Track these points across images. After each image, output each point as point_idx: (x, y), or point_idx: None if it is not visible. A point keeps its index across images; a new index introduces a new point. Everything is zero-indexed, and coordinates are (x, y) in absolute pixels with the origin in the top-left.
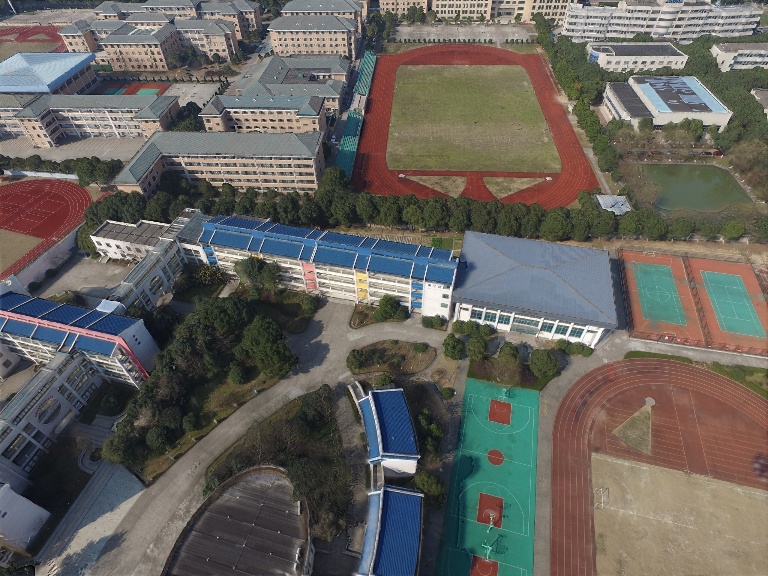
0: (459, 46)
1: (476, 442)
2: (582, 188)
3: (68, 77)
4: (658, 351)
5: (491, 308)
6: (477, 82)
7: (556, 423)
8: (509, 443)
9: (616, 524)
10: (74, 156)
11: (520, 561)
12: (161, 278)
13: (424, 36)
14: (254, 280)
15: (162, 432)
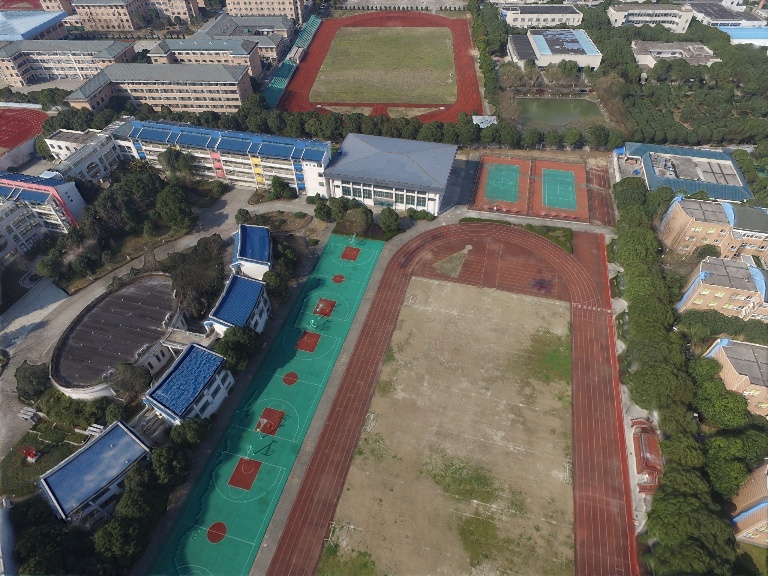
0: (398, 12)
1: (326, 270)
2: None
3: (41, 30)
4: (487, 218)
5: (355, 183)
6: (405, 40)
7: (391, 260)
8: (351, 271)
9: (415, 314)
10: None
11: (337, 334)
12: (98, 165)
13: (369, 5)
14: (173, 167)
15: (84, 259)
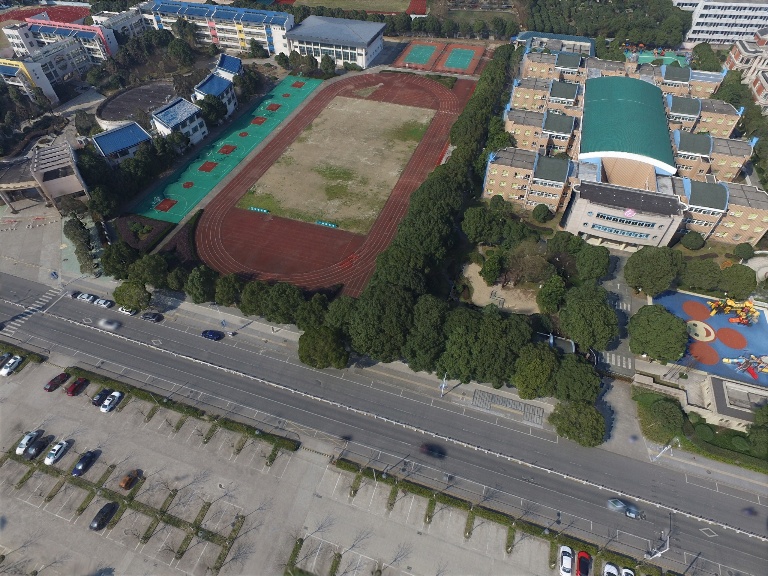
0: None
1: (279, 91)
2: None
3: None
4: None
5: (307, 42)
6: None
7: (325, 88)
8: (296, 92)
9: (332, 112)
10: None
11: (278, 118)
12: (129, 30)
13: None
14: (181, 33)
15: (117, 76)
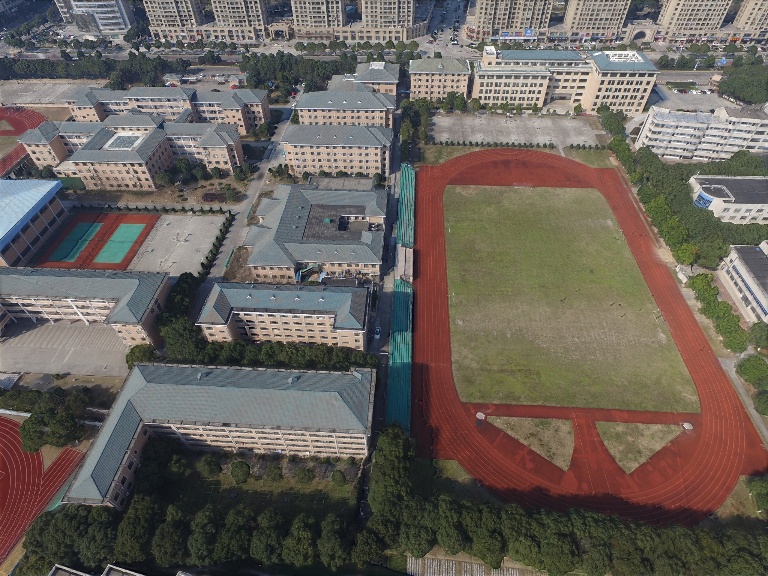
0: (513, 152)
1: None
2: (741, 450)
3: (23, 224)
4: None
5: None
6: (548, 220)
7: None
8: None
9: None
10: (24, 363)
11: None
12: None
13: (468, 134)
14: None
15: None
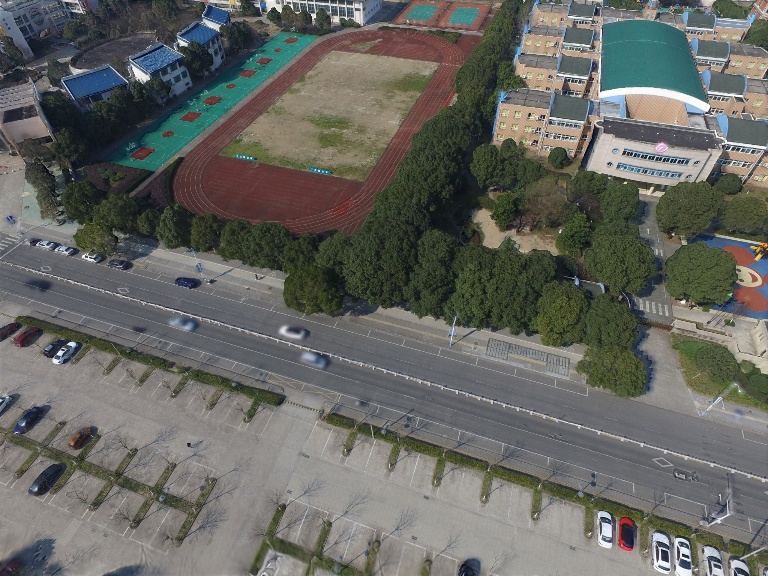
0: None
1: None
2: None
3: None
4: (400, 27)
5: None
6: None
7: (320, 43)
8: (289, 47)
9: (327, 65)
10: None
11: (269, 71)
12: None
13: None
14: None
15: (97, 31)
